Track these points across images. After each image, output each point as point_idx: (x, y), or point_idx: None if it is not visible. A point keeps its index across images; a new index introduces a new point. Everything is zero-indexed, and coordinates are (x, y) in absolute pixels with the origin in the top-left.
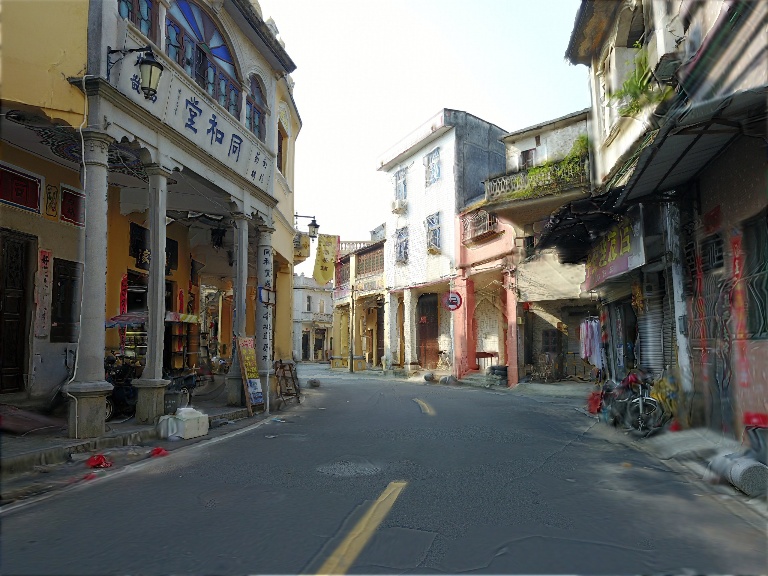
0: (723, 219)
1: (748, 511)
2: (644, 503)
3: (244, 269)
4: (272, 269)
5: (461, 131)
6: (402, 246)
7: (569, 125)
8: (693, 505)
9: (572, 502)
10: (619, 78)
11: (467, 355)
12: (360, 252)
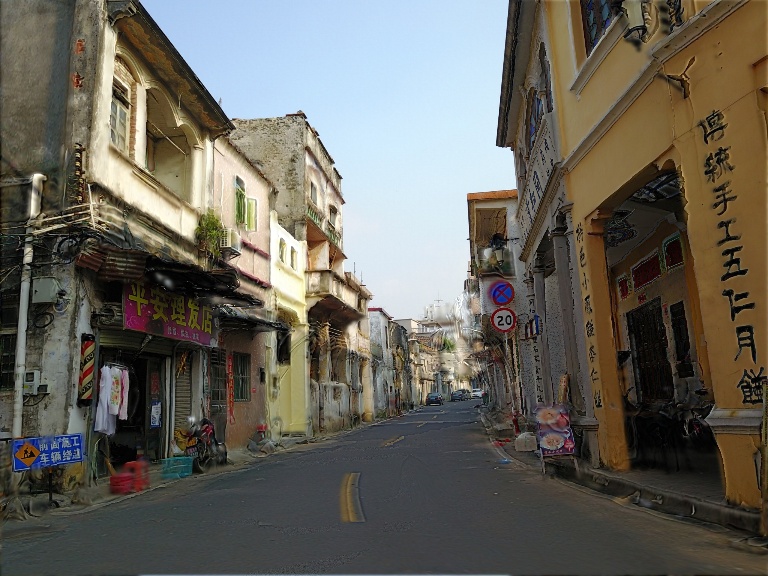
0: None
1: None
2: None
3: None
4: (587, 253)
5: None
6: None
7: None
8: None
9: (331, 447)
10: None
11: None
12: None
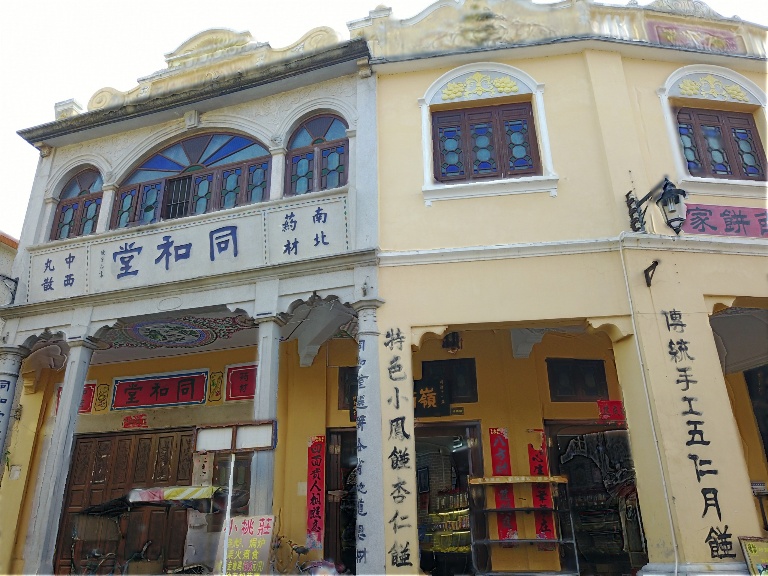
0: None
1: None
2: None
3: (261, 398)
4: (408, 367)
5: None
6: None
7: None
8: None
9: None
10: None
11: None
12: None
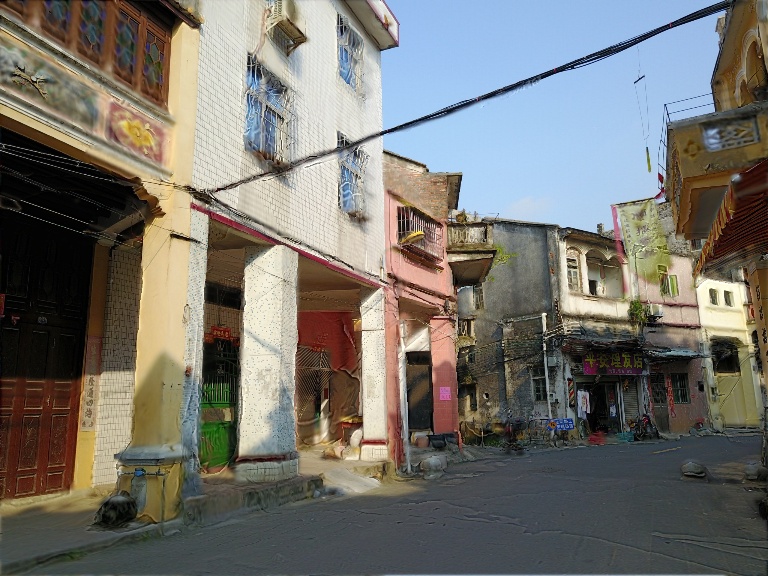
0: None
1: None
2: None
3: None
4: None
5: None
6: None
7: None
8: None
9: None
10: None
11: None
12: None
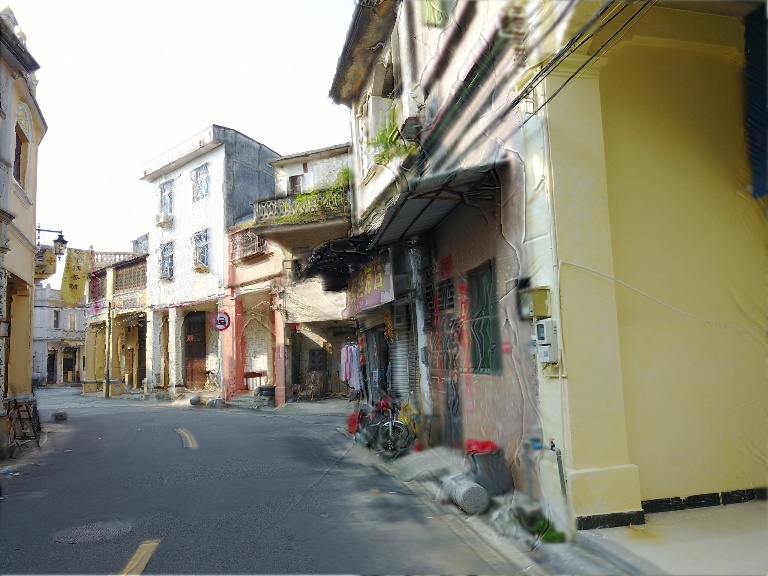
0: (453, 268)
1: (466, 529)
2: (385, 534)
3: None
4: (5, 294)
5: (231, 149)
6: (167, 262)
7: (334, 156)
8: (425, 529)
9: (323, 542)
10: (375, 124)
11: (235, 376)
12: (119, 266)
